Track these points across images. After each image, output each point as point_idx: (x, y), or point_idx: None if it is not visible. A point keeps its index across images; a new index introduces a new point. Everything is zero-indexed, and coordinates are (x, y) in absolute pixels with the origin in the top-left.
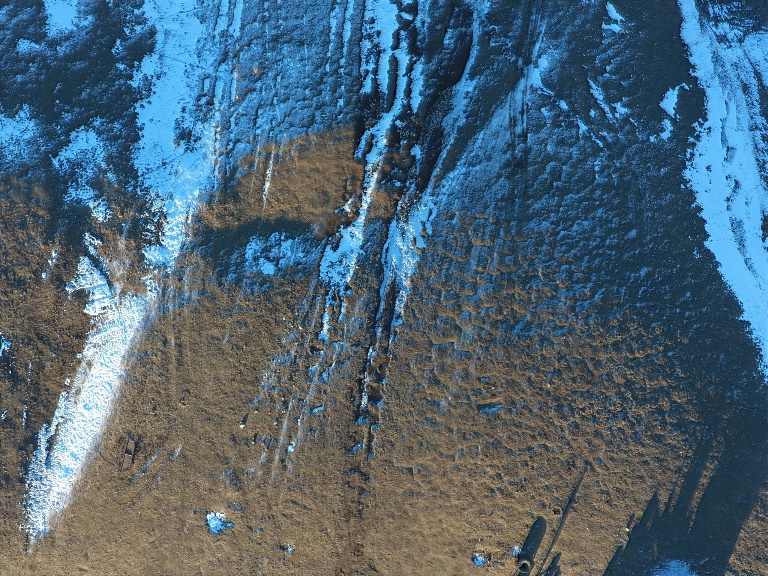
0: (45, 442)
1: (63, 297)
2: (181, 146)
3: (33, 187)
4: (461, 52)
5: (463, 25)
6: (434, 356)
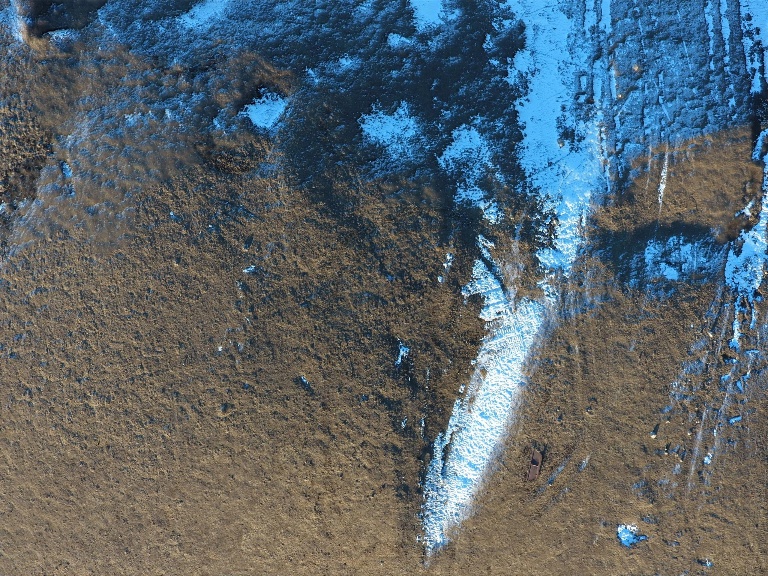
0: (441, 451)
1: (459, 302)
2: (566, 146)
3: (422, 187)
4: None
5: None
6: None
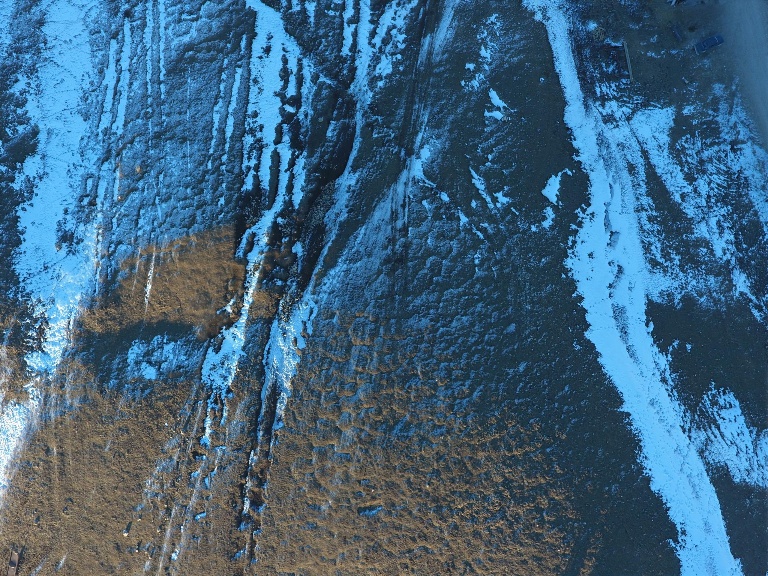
0: None
1: None
2: (63, 249)
3: None
4: (344, 144)
5: (346, 116)
6: (314, 459)
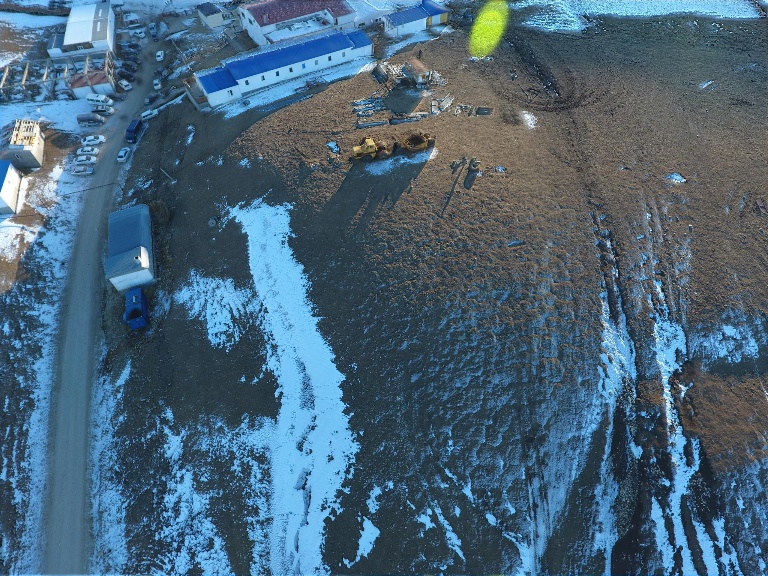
0: None
1: None
2: None
3: None
4: None
5: None
6: (567, 273)
